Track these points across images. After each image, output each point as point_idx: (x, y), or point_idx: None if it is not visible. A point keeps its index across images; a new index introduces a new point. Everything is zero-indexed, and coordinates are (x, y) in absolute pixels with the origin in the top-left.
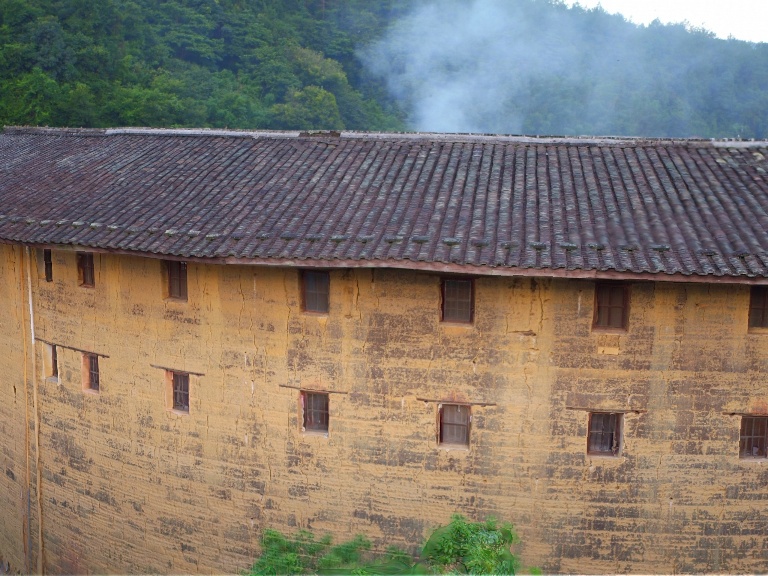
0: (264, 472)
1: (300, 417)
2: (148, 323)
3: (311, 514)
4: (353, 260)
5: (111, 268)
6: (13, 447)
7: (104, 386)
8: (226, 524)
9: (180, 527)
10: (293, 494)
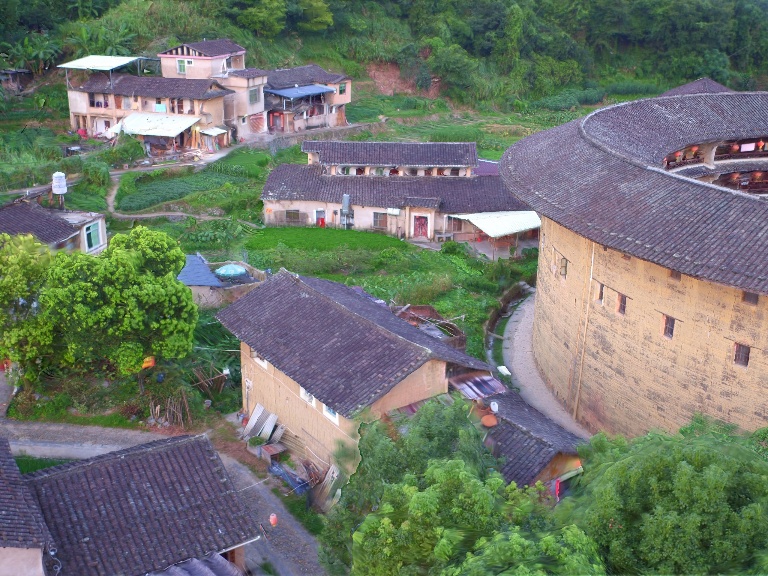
0: (709, 380)
1: (733, 356)
2: (657, 287)
3: (731, 407)
4: (766, 293)
5: None
6: (570, 331)
7: (628, 314)
8: (684, 401)
9: (658, 397)
10: (723, 395)
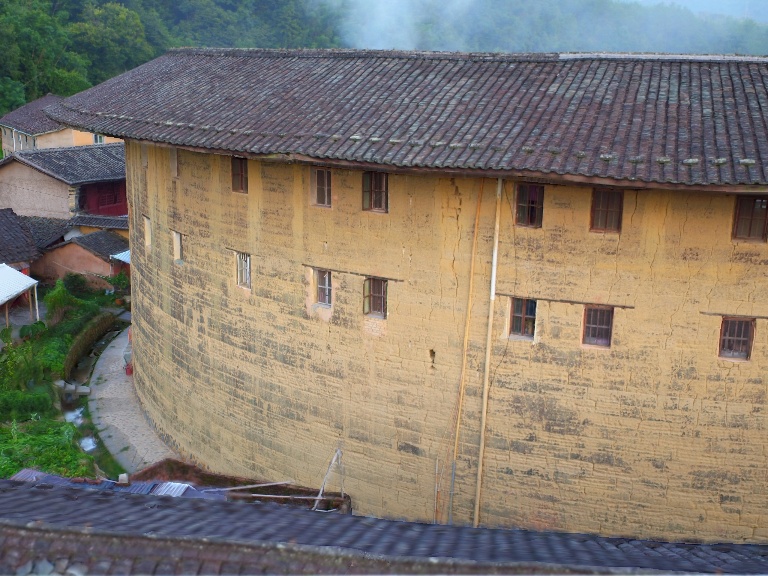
0: None
1: None
2: (705, 268)
3: None
4: None
5: (654, 210)
6: (420, 418)
7: (620, 340)
8: None
9: (722, 478)
10: None
